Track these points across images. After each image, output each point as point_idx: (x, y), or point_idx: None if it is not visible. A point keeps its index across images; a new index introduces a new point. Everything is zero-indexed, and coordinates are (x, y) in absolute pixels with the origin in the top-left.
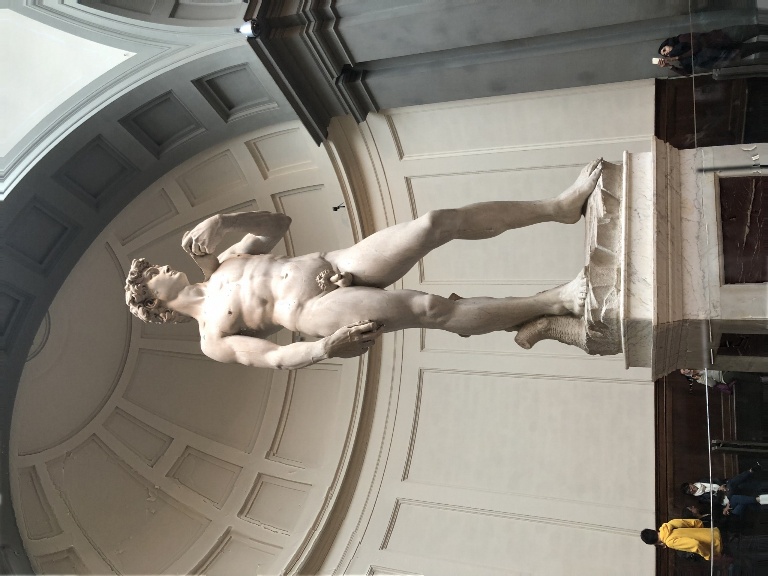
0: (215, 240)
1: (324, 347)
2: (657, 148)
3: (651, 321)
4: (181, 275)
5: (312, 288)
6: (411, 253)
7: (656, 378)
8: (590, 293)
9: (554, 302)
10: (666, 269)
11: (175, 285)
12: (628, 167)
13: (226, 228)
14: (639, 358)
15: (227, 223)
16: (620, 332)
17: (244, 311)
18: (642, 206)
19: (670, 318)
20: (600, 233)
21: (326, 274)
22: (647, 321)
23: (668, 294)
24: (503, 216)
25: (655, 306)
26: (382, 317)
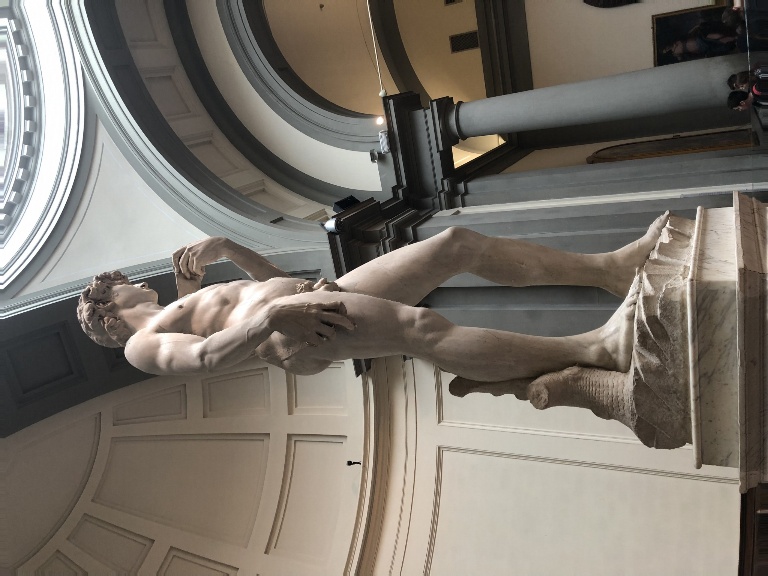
0: (209, 255)
1: (269, 309)
2: (739, 195)
3: (734, 290)
4: (153, 291)
5: (287, 288)
6: (418, 268)
7: (748, 486)
8: (643, 282)
9: (592, 341)
10: (756, 246)
11: (140, 295)
12: (702, 213)
13: (226, 248)
14: (718, 431)
15: (230, 244)
16: (687, 349)
17: (198, 309)
18: (720, 228)
19: (764, 271)
20: (663, 247)
21: (310, 282)
22: (728, 290)
23: (760, 259)
24: (540, 255)
25: (740, 258)
26: (357, 313)
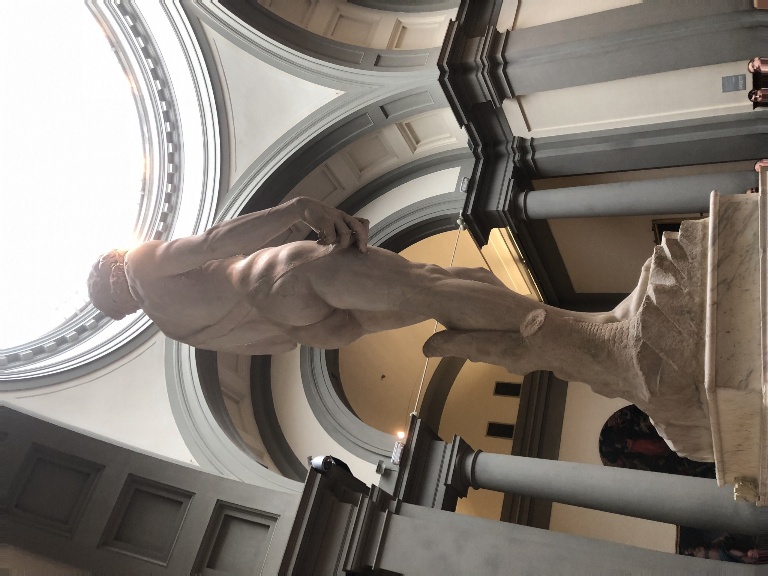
0: None
1: None
2: None
3: (757, 201)
4: None
5: None
6: None
7: None
8: None
9: None
10: None
11: None
12: None
13: None
14: (737, 344)
15: None
16: (705, 266)
17: None
18: None
19: None
20: None
21: None
22: (751, 201)
23: None
24: None
25: None
26: (374, 248)
